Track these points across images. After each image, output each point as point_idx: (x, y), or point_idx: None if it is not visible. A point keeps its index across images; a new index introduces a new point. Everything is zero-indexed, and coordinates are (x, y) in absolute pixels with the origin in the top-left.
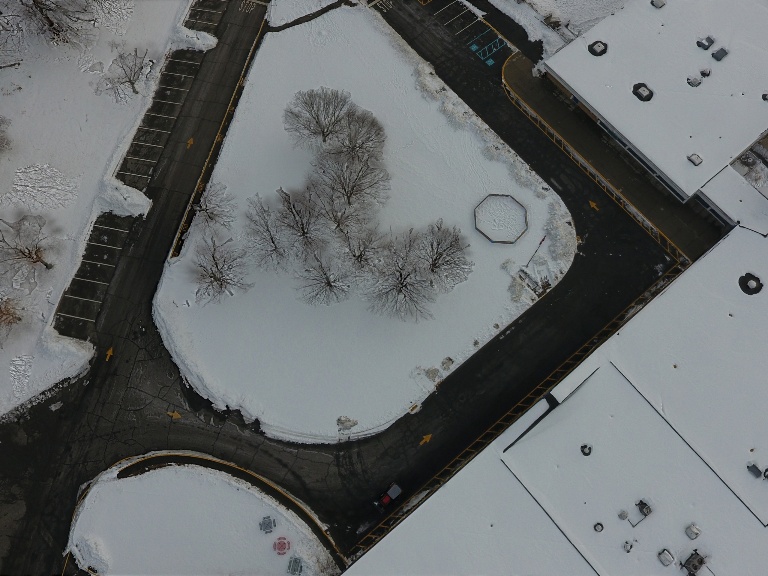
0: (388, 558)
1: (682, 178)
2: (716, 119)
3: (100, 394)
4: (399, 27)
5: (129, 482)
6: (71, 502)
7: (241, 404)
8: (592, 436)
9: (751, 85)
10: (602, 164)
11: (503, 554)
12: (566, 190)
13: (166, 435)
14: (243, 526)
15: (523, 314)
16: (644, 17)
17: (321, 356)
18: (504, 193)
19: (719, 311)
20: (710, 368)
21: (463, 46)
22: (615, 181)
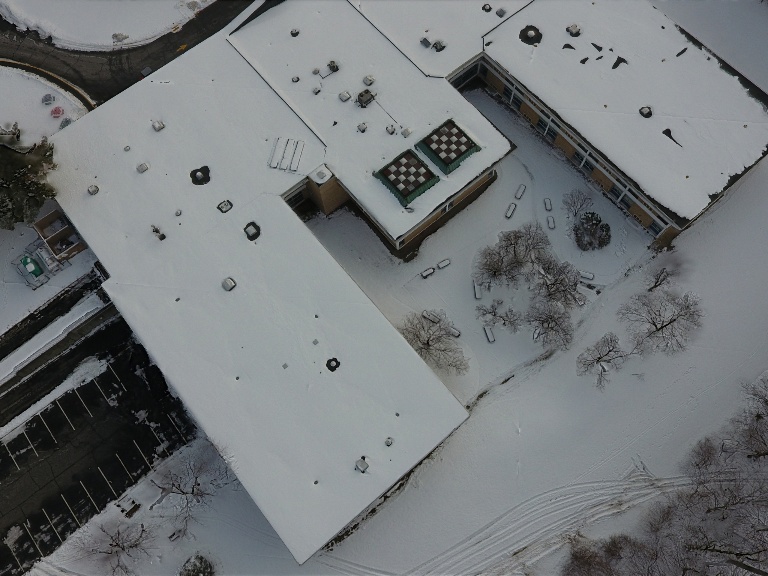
0: (129, 101)
1: None
2: None
3: None
4: None
5: None
6: None
7: (38, 25)
8: (301, 24)
9: None
10: None
11: (218, 97)
12: None
13: None
14: (30, 102)
15: None
16: None
17: None
18: None
19: None
20: None
21: None
22: None
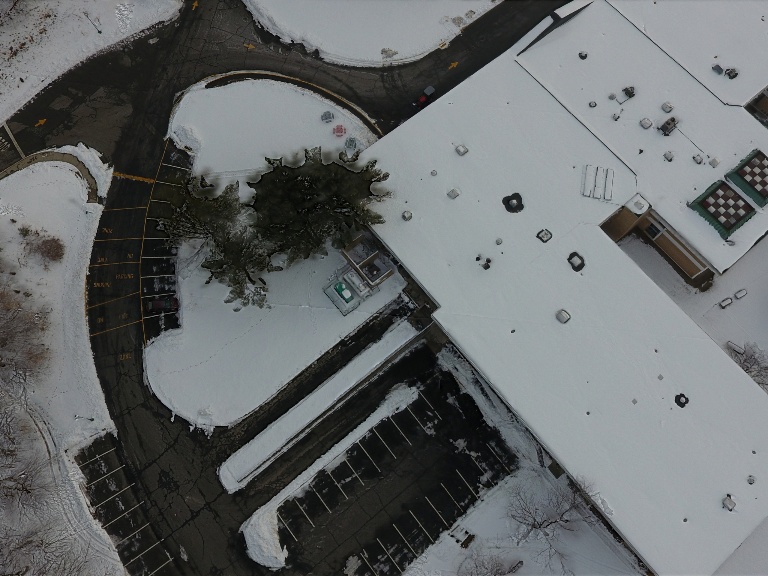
0: (426, 123)
1: None
2: None
3: (189, 32)
4: None
5: (215, 90)
6: (169, 104)
7: (304, 37)
8: (588, 46)
9: None
10: None
11: (517, 121)
12: None
13: (243, 60)
14: (308, 119)
15: None
16: None
17: (367, 7)
18: None
19: None
20: (683, 3)
21: None
22: None
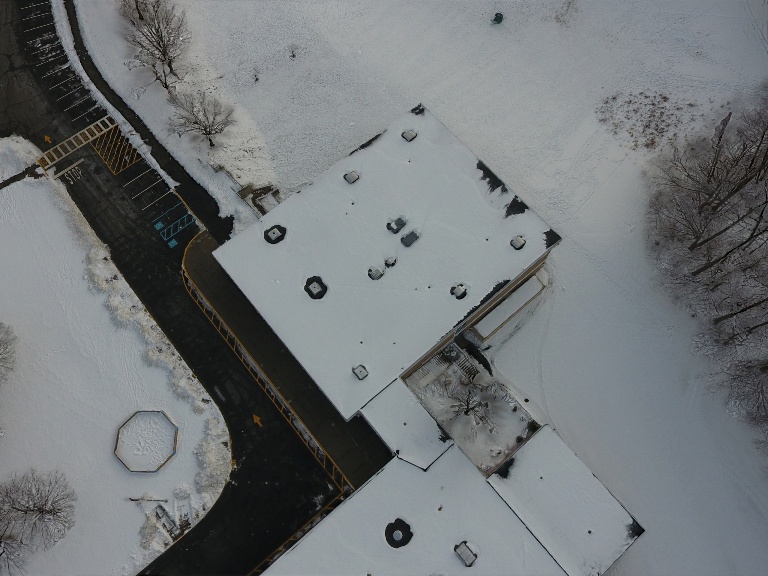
0: None
1: (341, 397)
2: (393, 320)
3: None
4: (82, 202)
5: None
6: None
7: None
8: None
9: (440, 276)
10: (274, 368)
11: None
12: (229, 401)
13: None
14: None
15: (152, 563)
16: (333, 195)
17: None
18: (157, 408)
19: (355, 571)
20: None
21: (147, 224)
22: (285, 390)
